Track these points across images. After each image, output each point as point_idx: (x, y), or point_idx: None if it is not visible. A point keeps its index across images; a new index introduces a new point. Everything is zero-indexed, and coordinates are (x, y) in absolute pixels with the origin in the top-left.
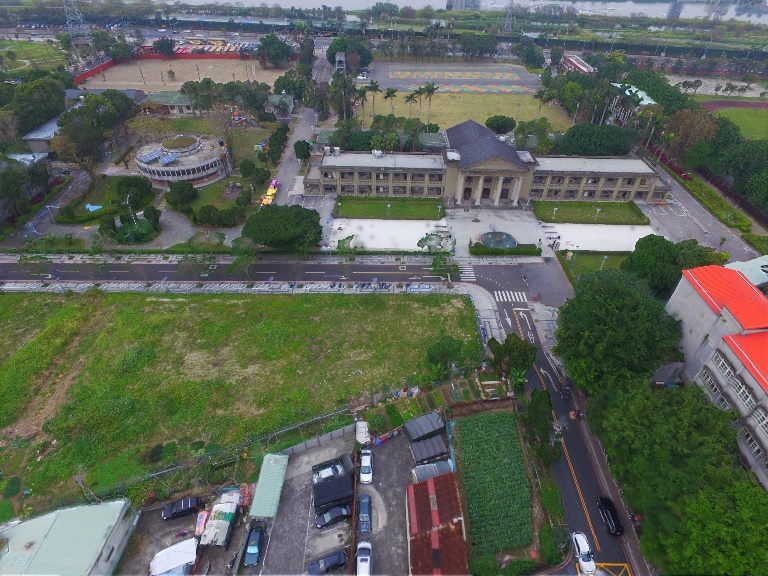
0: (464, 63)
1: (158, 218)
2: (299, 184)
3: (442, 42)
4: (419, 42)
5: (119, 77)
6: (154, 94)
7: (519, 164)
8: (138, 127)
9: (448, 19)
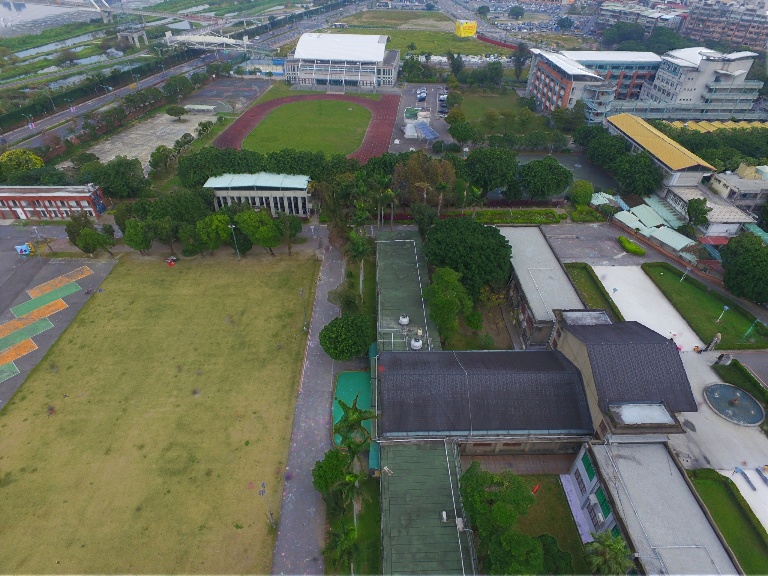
0: None
1: None
2: None
3: None
4: None
5: None
6: None
7: (643, 327)
8: None
9: None
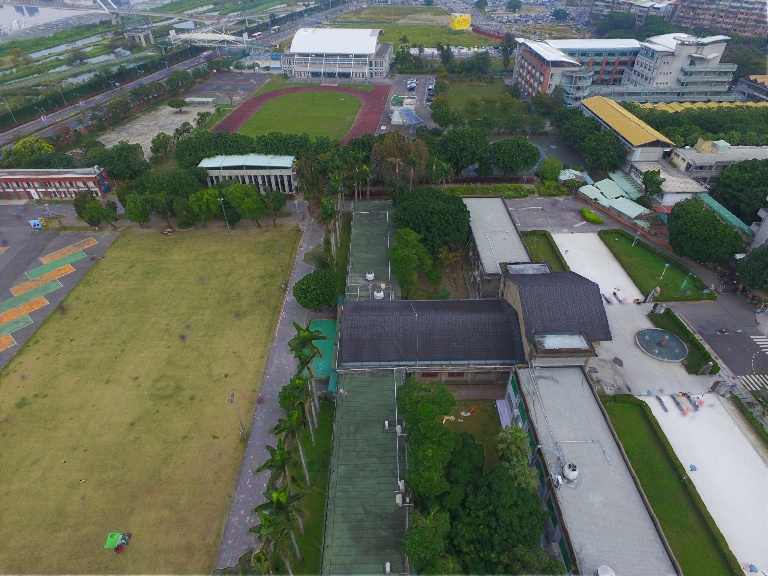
0: None
1: None
2: None
3: None
4: None
5: None
6: None
7: (576, 275)
8: None
9: None
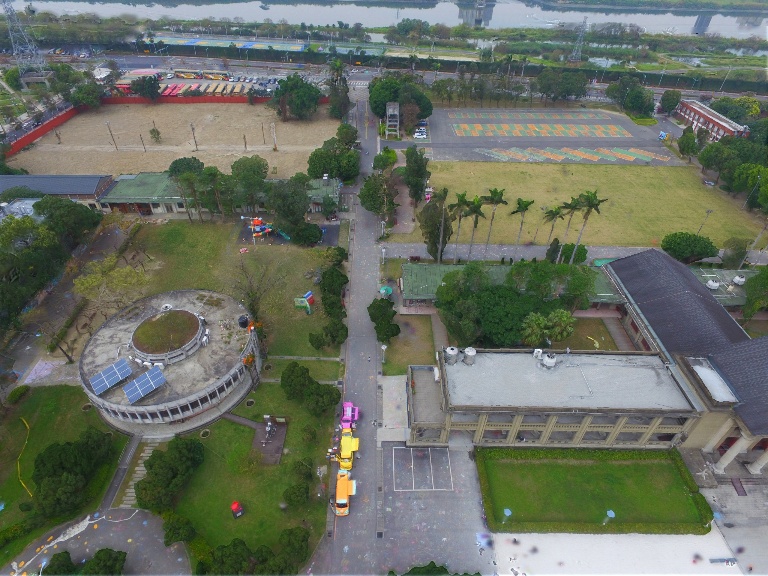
0: (544, 108)
1: (118, 573)
2: (391, 404)
3: (512, 79)
4: (488, 82)
5: (81, 136)
6: (128, 179)
7: None
8: (90, 290)
9: (497, 42)
